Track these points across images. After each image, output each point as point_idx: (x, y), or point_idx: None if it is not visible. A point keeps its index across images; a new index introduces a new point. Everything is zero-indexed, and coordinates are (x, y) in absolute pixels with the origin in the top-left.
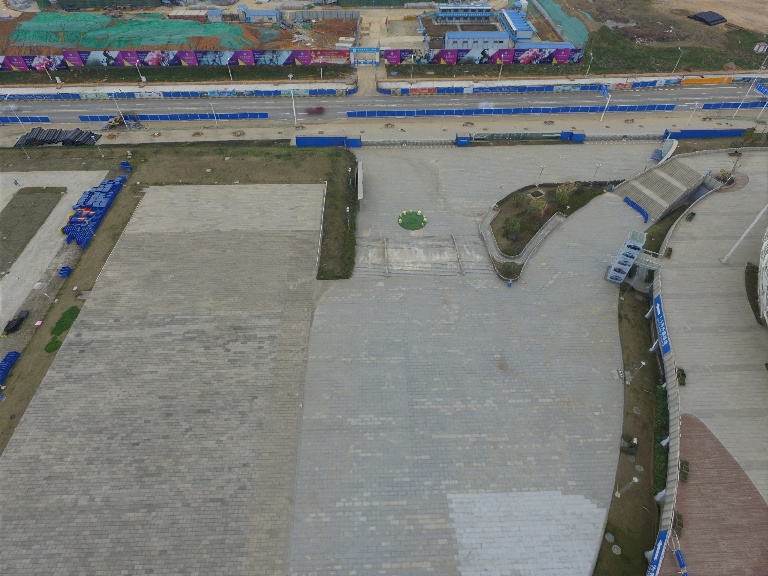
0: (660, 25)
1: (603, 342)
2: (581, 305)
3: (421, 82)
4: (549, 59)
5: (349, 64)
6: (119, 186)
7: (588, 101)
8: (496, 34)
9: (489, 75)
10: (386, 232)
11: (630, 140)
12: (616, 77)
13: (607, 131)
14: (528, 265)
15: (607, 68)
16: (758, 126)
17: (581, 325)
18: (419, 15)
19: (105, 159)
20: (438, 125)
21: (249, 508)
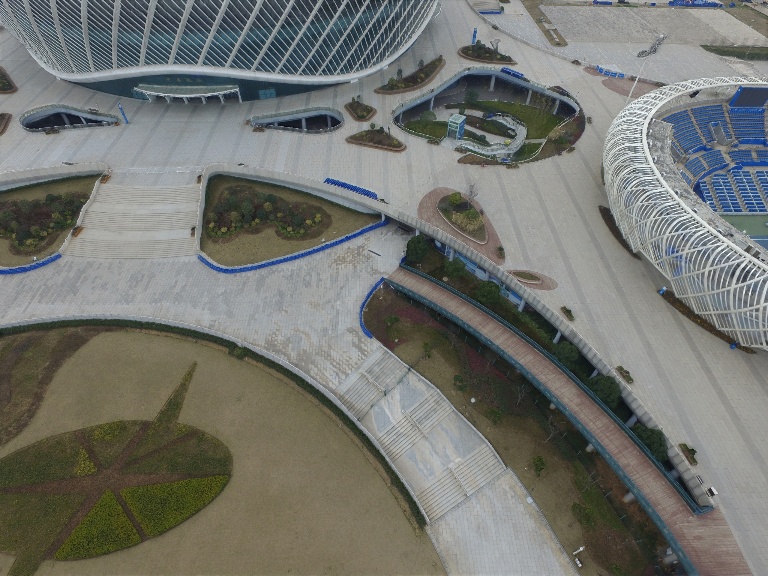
0: None
1: None
2: None
3: None
4: None
5: None
6: (715, 6)
7: None
8: None
9: None
10: (759, 68)
11: None
12: None
13: None
14: None
15: None
16: None
17: None
18: None
19: (732, 2)
20: None
21: (587, 36)
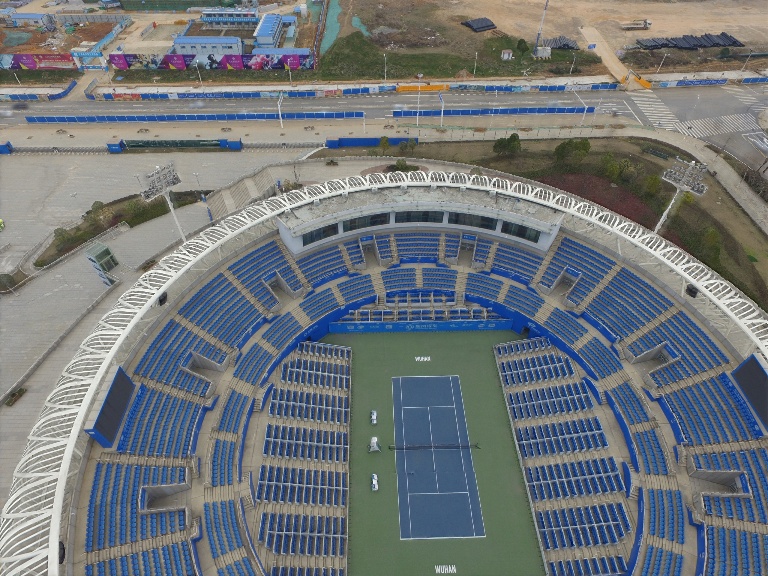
0: (425, 31)
1: (35, 358)
2: (53, 319)
3: (140, 87)
4: (280, 65)
5: (77, 69)
6: None
7: (287, 108)
8: (224, 39)
9: (214, 81)
10: None
11: (291, 148)
12: (341, 83)
13: (277, 138)
14: (41, 277)
15: (338, 74)
16: (434, 134)
17: (31, 340)
18: (192, 20)
19: None
20: (113, 131)
21: None
